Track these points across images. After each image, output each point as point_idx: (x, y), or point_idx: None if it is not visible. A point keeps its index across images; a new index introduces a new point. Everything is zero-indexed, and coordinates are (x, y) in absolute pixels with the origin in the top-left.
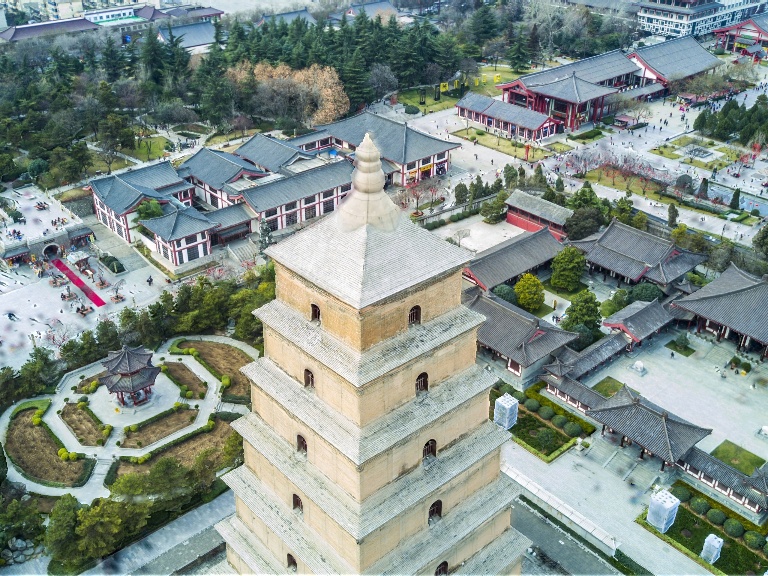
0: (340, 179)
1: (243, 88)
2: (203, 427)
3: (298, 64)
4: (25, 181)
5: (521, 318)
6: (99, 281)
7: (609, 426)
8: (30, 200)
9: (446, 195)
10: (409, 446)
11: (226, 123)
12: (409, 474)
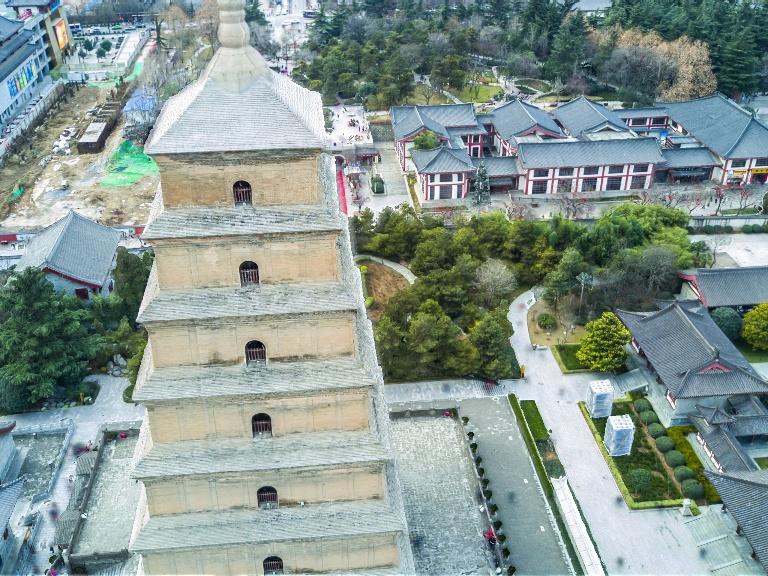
0: (635, 157)
1: (601, 52)
2: None
3: (673, 36)
4: (356, 100)
5: (704, 343)
6: (356, 195)
7: (722, 498)
8: (349, 116)
9: (759, 203)
10: (222, 334)
11: (559, 82)
12: (224, 367)
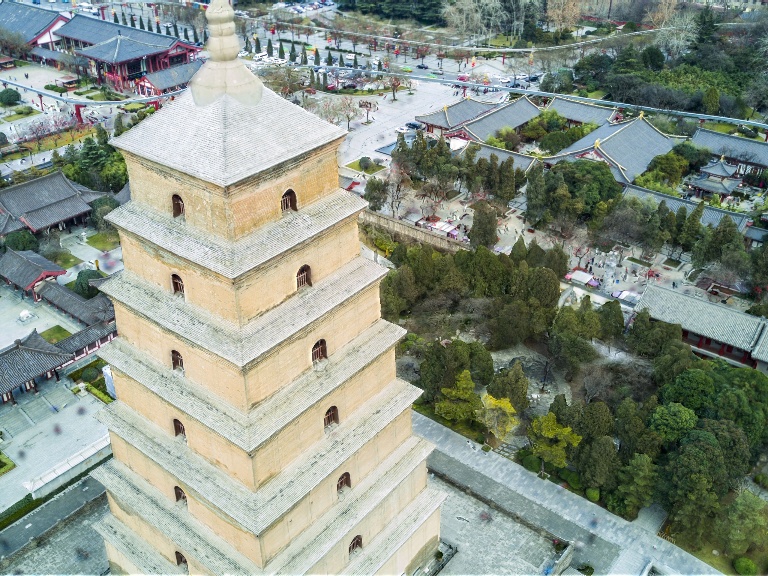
0: None
1: None
2: None
3: None
4: None
5: None
6: None
7: (4, 393)
8: None
9: None
10: None
11: None
12: None
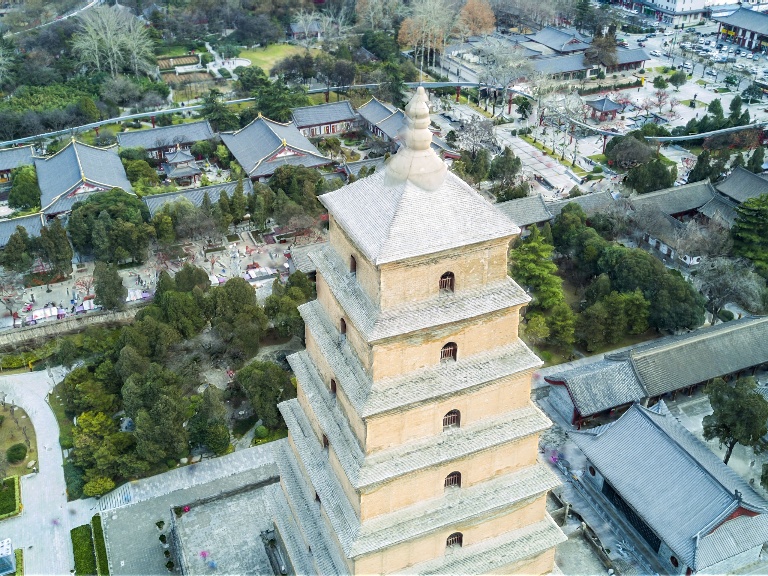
0: None
1: None
2: None
3: None
4: None
5: None
6: None
7: None
8: None
9: None
10: None
11: None
12: None
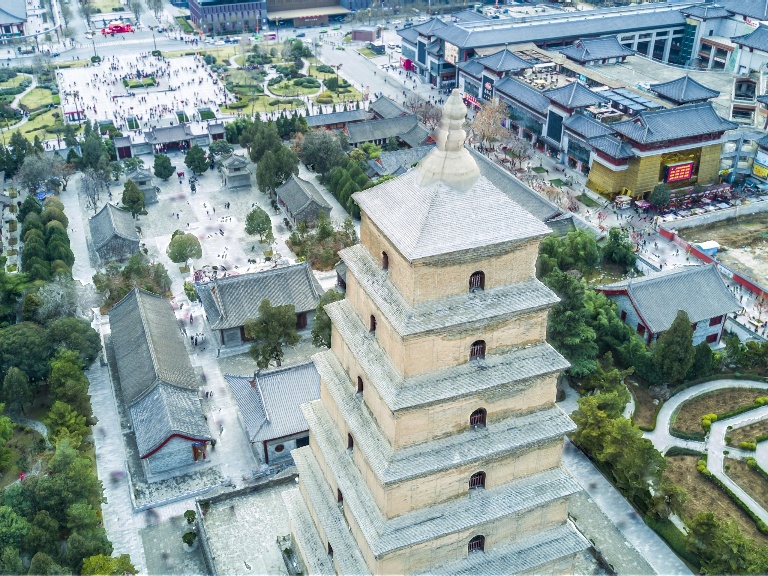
0: None
1: None
2: (761, 520)
3: None
4: None
5: None
6: None
7: None
8: None
9: None
10: None
11: None
12: None
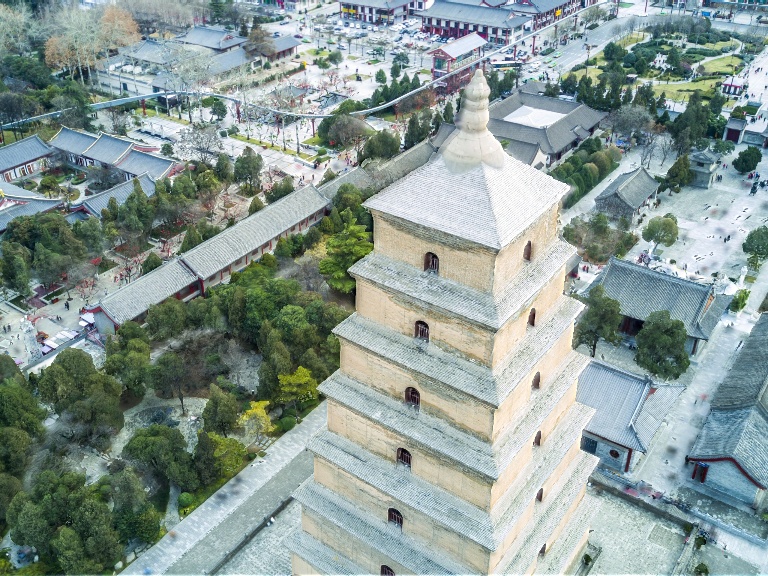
0: None
1: None
2: None
3: None
4: None
5: None
6: None
7: None
8: None
9: None
10: None
11: None
12: None
